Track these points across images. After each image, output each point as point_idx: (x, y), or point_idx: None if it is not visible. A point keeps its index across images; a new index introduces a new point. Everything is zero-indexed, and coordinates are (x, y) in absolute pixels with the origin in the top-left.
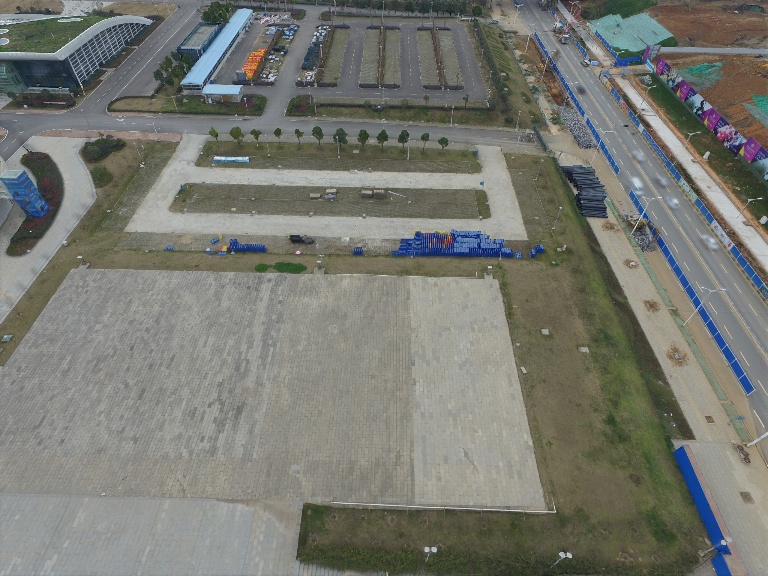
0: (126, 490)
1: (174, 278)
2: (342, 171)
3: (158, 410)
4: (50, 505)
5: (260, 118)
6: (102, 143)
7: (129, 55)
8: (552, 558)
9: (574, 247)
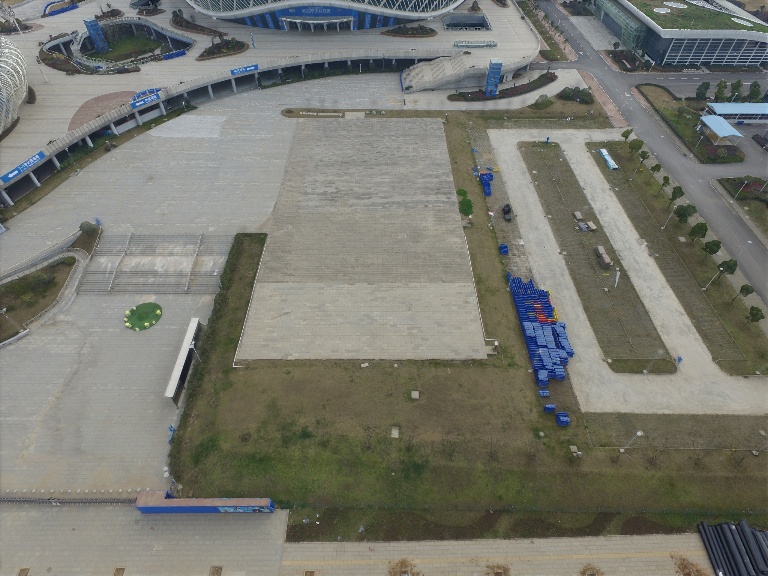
0: (288, 170)
1: (441, 155)
2: (637, 232)
3: (334, 170)
4: (285, 151)
5: (697, 164)
6: (583, 94)
7: (745, 72)
8: (205, 362)
9: (586, 470)
